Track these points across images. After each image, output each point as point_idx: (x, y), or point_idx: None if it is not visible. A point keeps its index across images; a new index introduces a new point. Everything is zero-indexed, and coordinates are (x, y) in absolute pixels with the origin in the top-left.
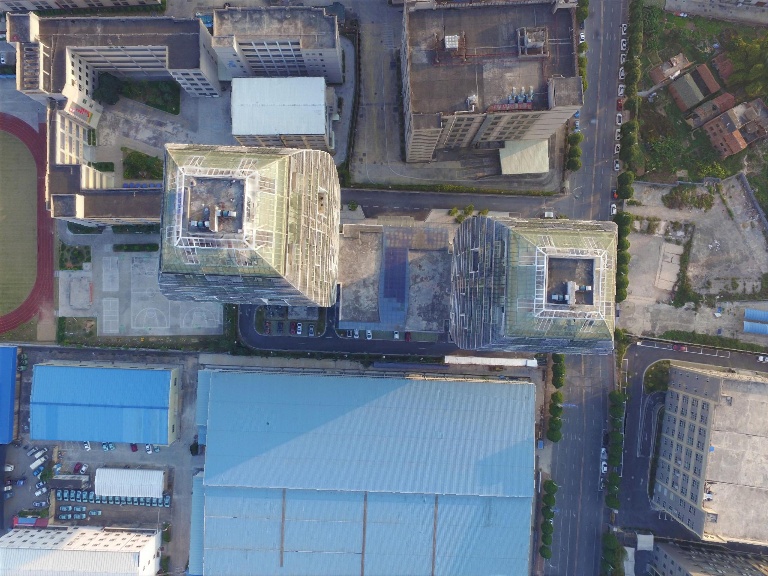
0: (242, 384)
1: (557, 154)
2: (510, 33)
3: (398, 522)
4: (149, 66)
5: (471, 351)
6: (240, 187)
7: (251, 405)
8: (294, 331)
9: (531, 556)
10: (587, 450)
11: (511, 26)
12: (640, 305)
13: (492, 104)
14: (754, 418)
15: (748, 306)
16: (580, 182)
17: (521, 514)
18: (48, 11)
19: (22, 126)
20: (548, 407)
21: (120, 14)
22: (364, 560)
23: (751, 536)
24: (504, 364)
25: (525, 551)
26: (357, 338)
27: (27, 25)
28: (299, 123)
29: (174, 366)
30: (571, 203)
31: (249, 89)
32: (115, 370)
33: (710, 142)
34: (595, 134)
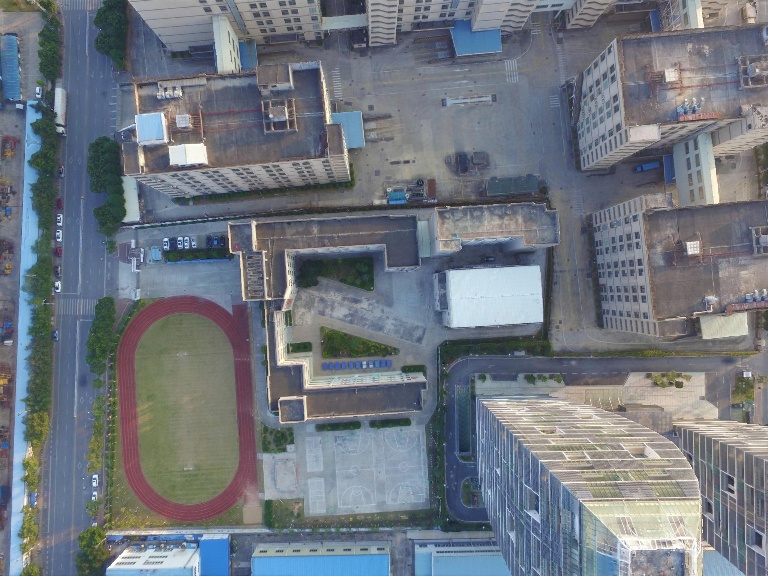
0: (464, 567)
1: None
2: (743, 231)
3: None
4: (349, 250)
5: None
6: (679, 554)
7: None
8: None
9: None
10: None
11: (743, 223)
12: None
13: (729, 303)
14: None
15: None
16: None
17: None
18: (238, 193)
19: (216, 309)
20: None
21: (309, 192)
22: None
23: None
24: None
25: None
26: None
27: (248, 233)
28: (518, 313)
29: (383, 543)
30: (765, 359)
31: (467, 281)
32: (333, 557)
33: None
34: None
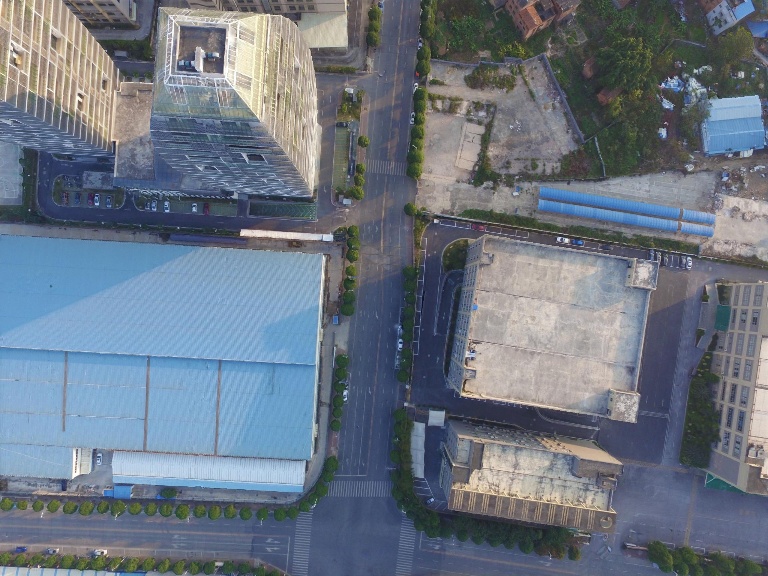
0: (27, 247)
1: (362, 33)
2: None
3: (181, 388)
4: None
5: (270, 226)
6: None
7: (35, 268)
8: (92, 202)
9: (326, 432)
10: (384, 328)
11: None
12: (440, 184)
13: None
14: (521, 279)
15: (546, 186)
16: (384, 61)
17: (305, 383)
18: None
19: None
20: (343, 282)
21: None
22: (147, 426)
23: (515, 396)
24: (300, 238)
25: (309, 420)
26: (155, 210)
27: None
28: None
29: None
30: (374, 81)
31: None
32: None
33: (513, 23)
34: (400, 13)
